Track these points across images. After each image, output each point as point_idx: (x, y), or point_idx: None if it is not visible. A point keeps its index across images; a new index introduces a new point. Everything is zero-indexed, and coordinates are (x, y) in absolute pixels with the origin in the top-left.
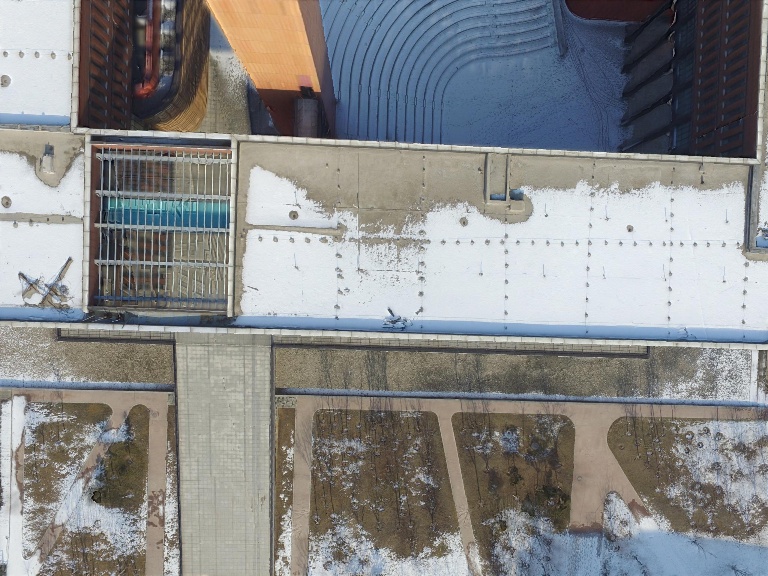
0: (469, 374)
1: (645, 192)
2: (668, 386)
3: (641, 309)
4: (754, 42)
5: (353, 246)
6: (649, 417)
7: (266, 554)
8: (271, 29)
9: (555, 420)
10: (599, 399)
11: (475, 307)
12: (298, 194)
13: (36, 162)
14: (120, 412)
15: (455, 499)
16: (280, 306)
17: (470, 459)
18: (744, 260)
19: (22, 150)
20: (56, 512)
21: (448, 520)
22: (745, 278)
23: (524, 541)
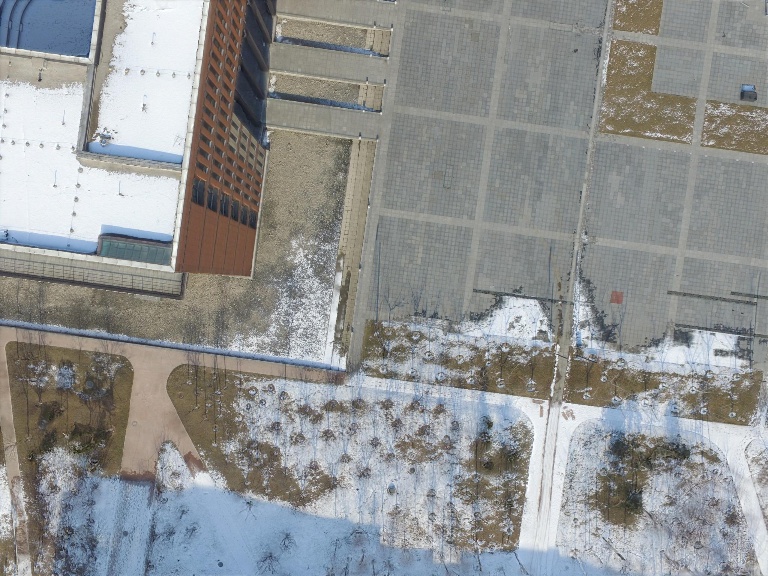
0: (31, 304)
1: None
2: (238, 338)
3: None
4: None
5: None
6: (212, 367)
7: None
8: None
9: (113, 360)
10: (164, 344)
11: None
12: None
13: None
14: None
15: (3, 430)
16: None
17: (22, 391)
18: (78, 165)
19: None
20: None
21: None
22: (77, 184)
23: (70, 482)
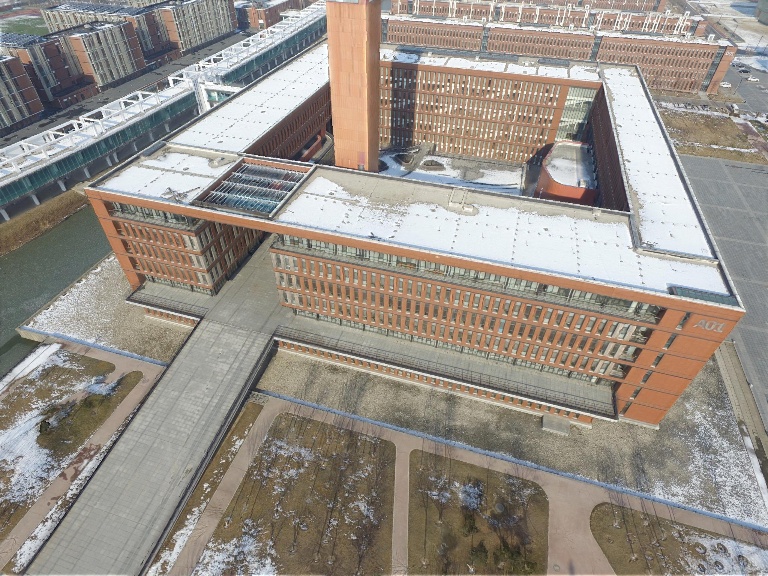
0: (437, 420)
1: (556, 217)
2: (659, 485)
3: (556, 263)
4: None
5: (360, 208)
6: (640, 511)
7: (151, 544)
8: (352, 109)
9: (525, 485)
10: (577, 478)
11: (431, 242)
12: (338, 188)
13: (212, 161)
14: (120, 372)
15: (394, 548)
16: (303, 220)
17: (422, 503)
18: (635, 254)
19: (209, 157)
20: None
21: (379, 572)
22: (638, 262)
23: None
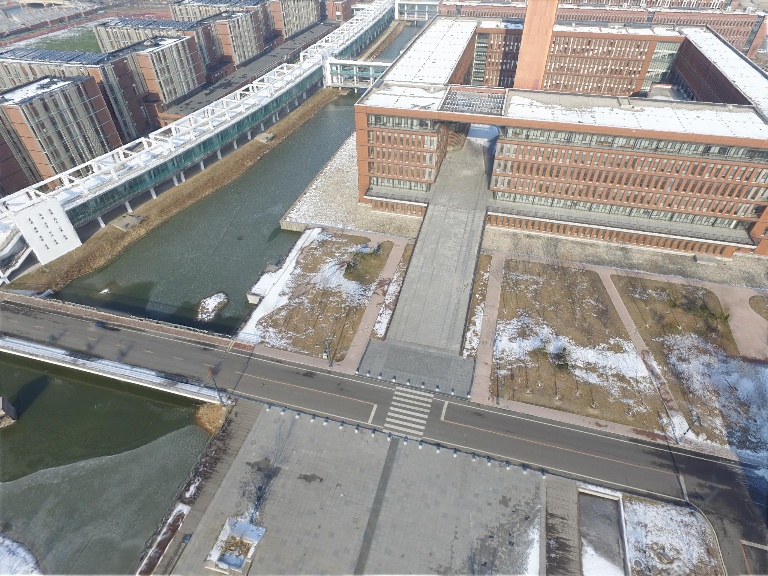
0: (619, 260)
1: None
2: None
3: None
4: (734, 92)
5: (559, 110)
6: None
7: (462, 321)
8: (537, 45)
9: (697, 289)
10: None
11: None
12: None
13: None
14: (376, 242)
15: (623, 320)
16: None
17: (630, 300)
18: (767, 126)
19: None
20: (313, 277)
21: (619, 330)
22: None
23: (698, 358)
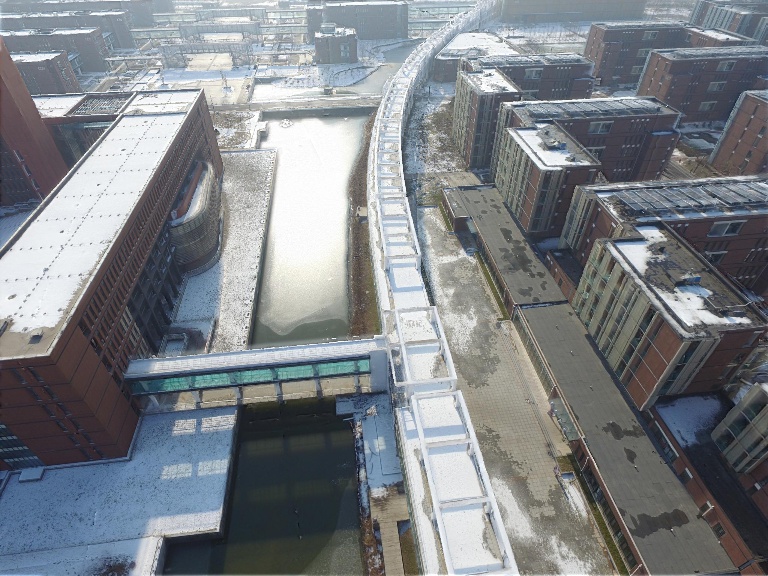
0: None
1: None
2: None
3: None
4: None
5: None
6: None
7: None
8: None
9: None
10: None
11: None
12: None
13: None
14: None
15: None
16: None
17: None
18: None
19: None
20: None
21: None
22: None
23: None
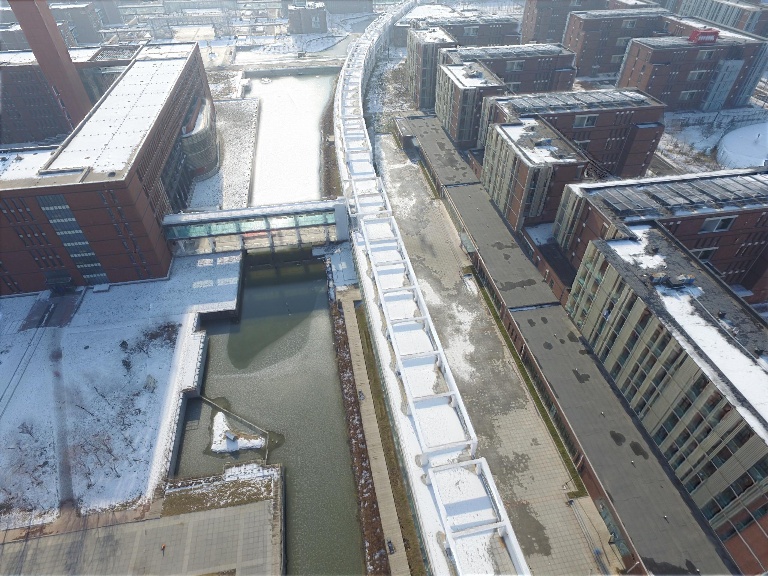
0: None
1: None
2: None
3: None
4: None
5: None
6: None
7: None
8: None
9: None
10: None
11: None
12: None
13: None
14: None
15: None
16: None
17: None
18: None
19: None
20: None
21: None
22: None
23: None
